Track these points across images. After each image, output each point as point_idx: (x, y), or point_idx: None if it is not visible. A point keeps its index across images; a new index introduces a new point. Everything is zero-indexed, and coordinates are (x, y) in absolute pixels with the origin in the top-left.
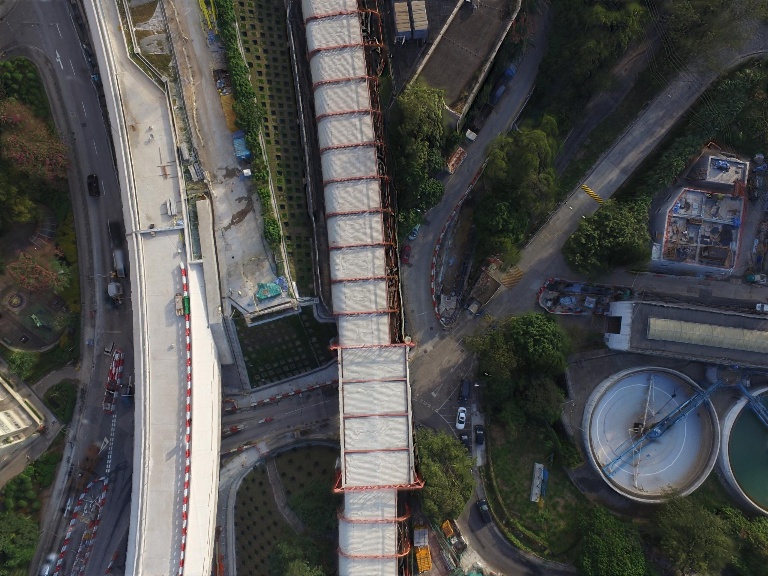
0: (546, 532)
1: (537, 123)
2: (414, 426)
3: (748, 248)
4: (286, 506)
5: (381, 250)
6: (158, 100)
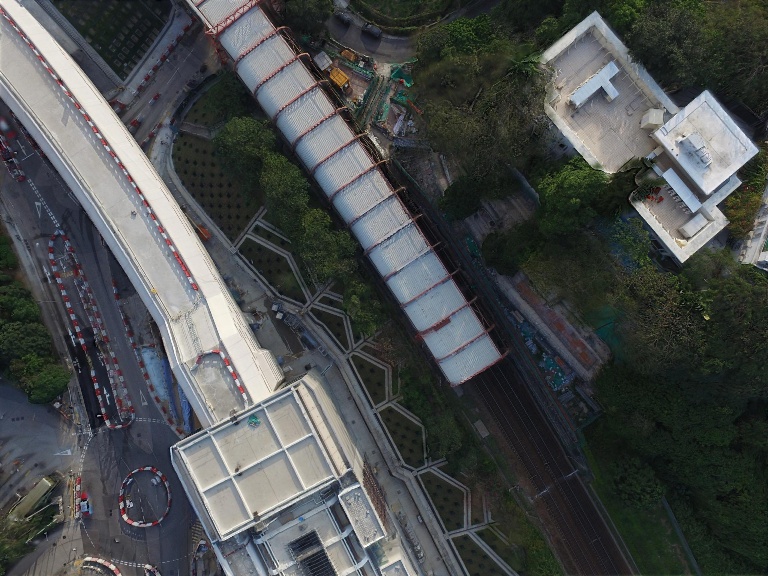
0: None
1: None
2: None
3: None
4: (210, 133)
5: None
6: None
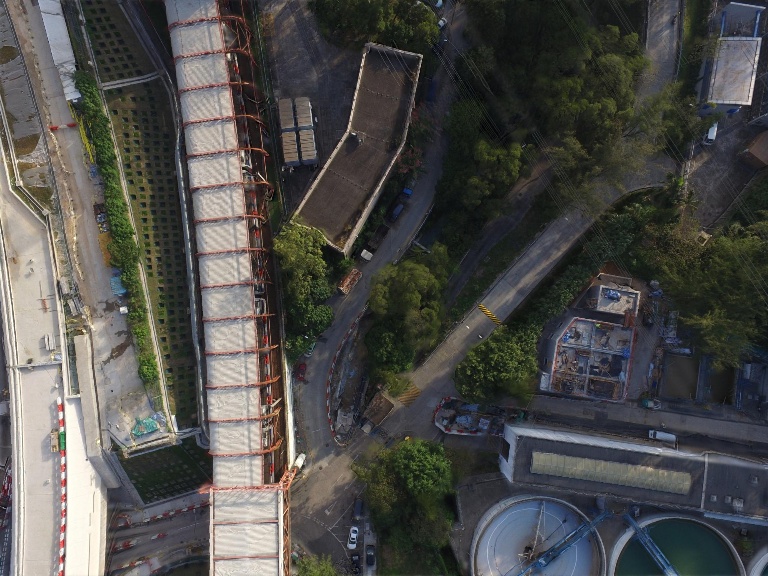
0: None
1: (438, 238)
2: (290, 562)
3: (643, 373)
4: None
5: (256, 390)
6: (40, 232)
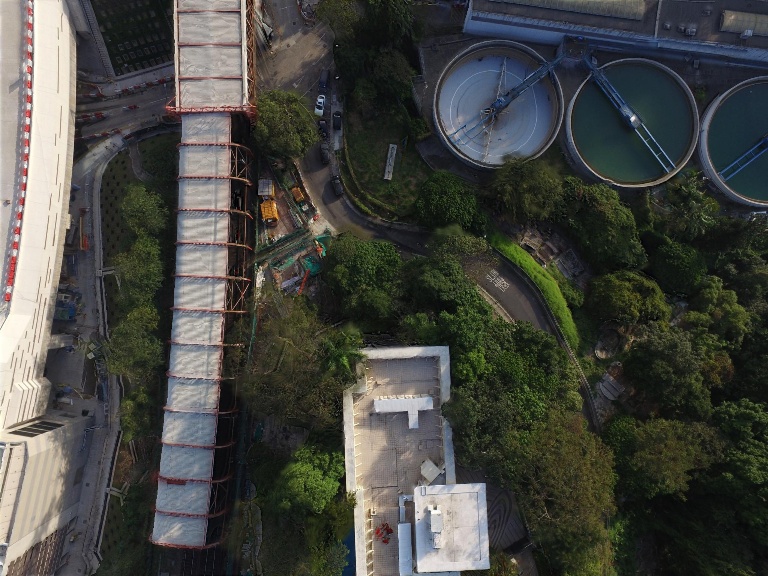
0: (396, 206)
1: None
2: (255, 72)
3: None
4: (142, 172)
5: None
6: None
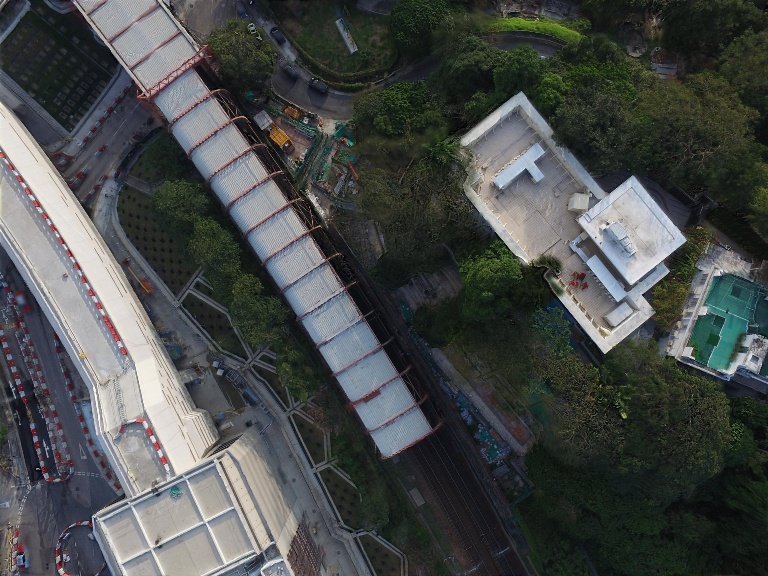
0: None
1: None
2: None
3: None
4: (152, 188)
5: None
6: None
